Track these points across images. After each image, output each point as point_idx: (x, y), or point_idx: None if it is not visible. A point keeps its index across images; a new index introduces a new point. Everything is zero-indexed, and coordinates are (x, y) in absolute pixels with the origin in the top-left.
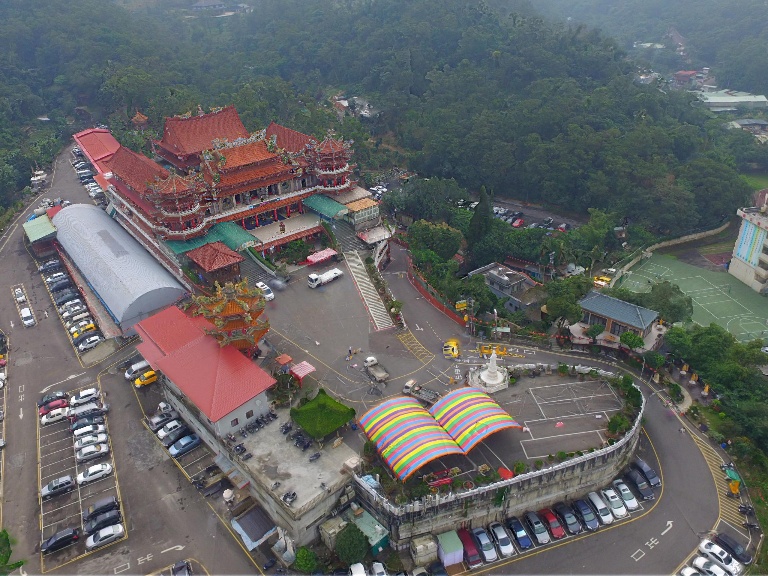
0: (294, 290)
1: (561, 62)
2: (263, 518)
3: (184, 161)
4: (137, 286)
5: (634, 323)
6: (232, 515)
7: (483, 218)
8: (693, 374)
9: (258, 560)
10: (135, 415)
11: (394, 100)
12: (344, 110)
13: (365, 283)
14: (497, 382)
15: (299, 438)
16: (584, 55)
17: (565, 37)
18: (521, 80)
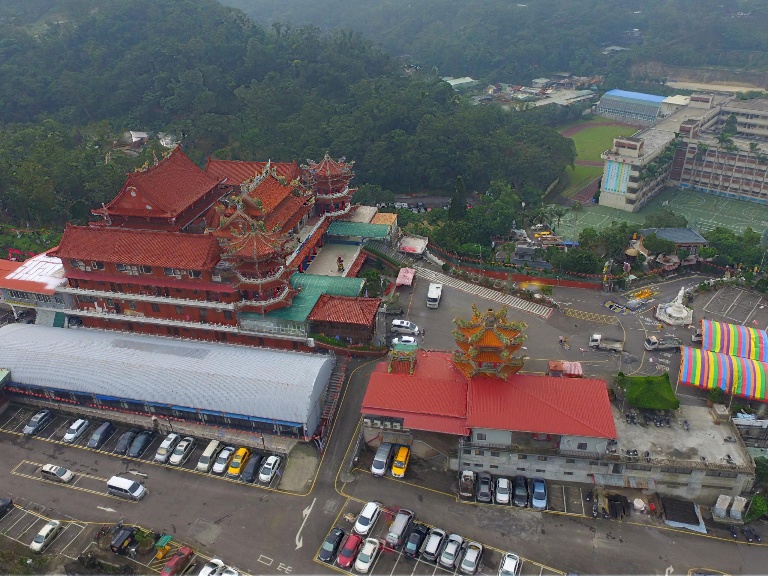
0: (422, 317)
1: (362, 64)
2: (678, 504)
3: (173, 223)
4: (292, 374)
5: (698, 240)
6: (661, 517)
7: (462, 206)
8: (741, 263)
9: (721, 535)
10: (444, 501)
11: (216, 124)
12: (141, 146)
13: (469, 287)
14: (687, 313)
15: (656, 419)
16: (371, 56)
17: (343, 42)
18: (327, 86)
